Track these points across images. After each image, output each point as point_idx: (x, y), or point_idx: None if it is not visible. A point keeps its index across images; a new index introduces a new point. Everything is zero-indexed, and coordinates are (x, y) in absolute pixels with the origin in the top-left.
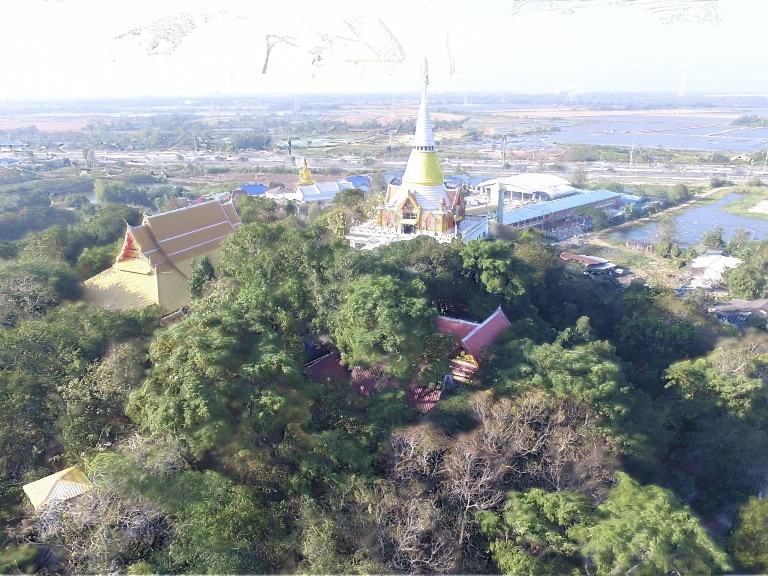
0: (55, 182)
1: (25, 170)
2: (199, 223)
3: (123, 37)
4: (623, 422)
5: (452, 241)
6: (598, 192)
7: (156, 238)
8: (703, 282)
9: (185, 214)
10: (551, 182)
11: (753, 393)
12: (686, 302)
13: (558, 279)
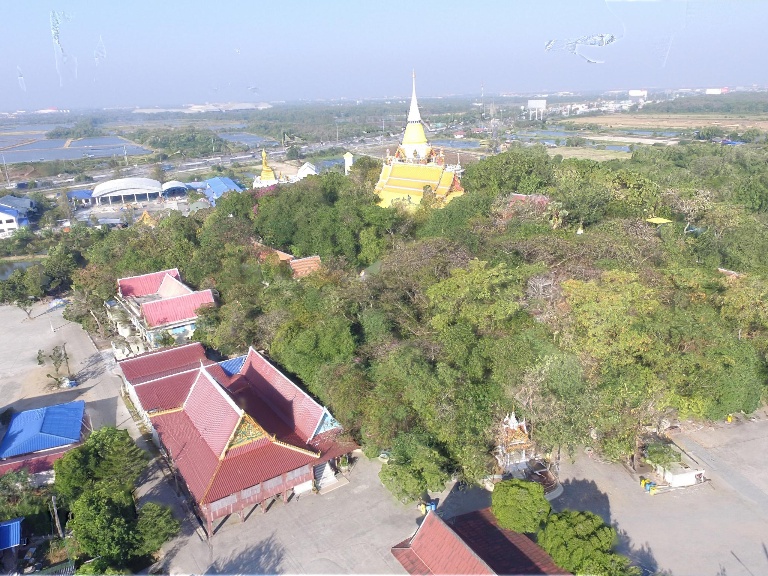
0: None
1: None
2: None
3: None
4: None
5: (467, 166)
6: (221, 178)
7: None
8: None
9: None
10: (152, 182)
11: None
12: None
13: None
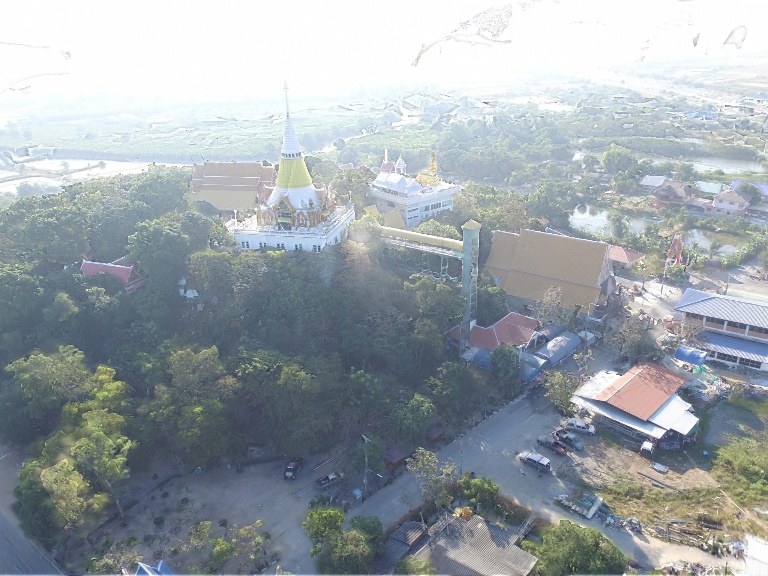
0: (648, 141)
1: (680, 126)
2: (237, 173)
3: (455, 32)
4: (1, 319)
5: None
6: None
7: (204, 174)
8: (692, 562)
9: (231, 166)
10: None
11: (16, 375)
12: (447, 473)
13: (230, 292)
